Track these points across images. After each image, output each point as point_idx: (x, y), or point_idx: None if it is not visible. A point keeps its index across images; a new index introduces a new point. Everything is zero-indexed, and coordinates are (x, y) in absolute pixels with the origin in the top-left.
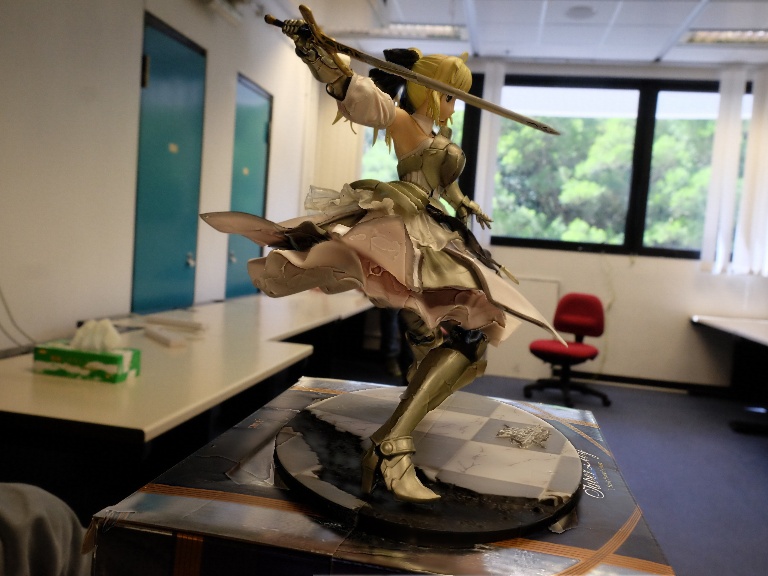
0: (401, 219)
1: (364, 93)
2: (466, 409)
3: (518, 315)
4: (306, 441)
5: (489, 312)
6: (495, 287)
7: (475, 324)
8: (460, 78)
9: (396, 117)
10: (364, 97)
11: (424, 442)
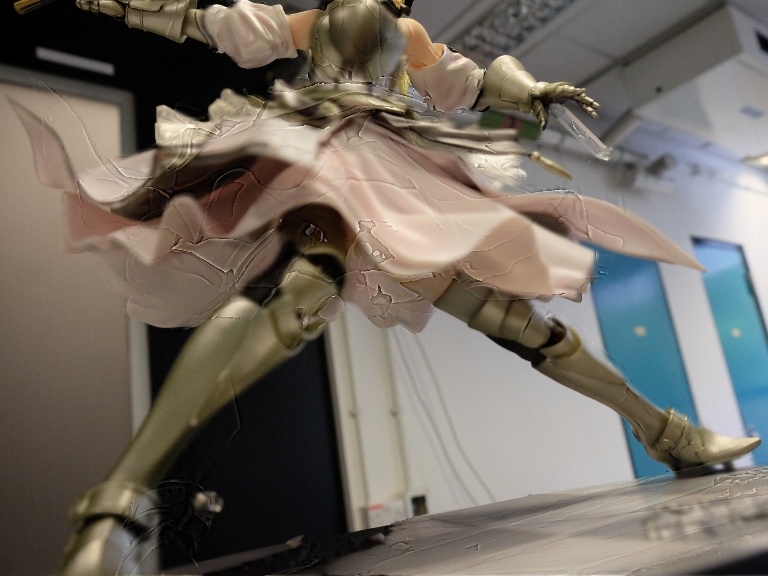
0: (23, 68)
1: (220, 15)
2: (736, 468)
3: (300, 113)
4: (303, 570)
5: (330, 164)
6: (285, 100)
7: (298, 199)
8: None
9: (291, 21)
10: (220, 20)
11: (510, 536)
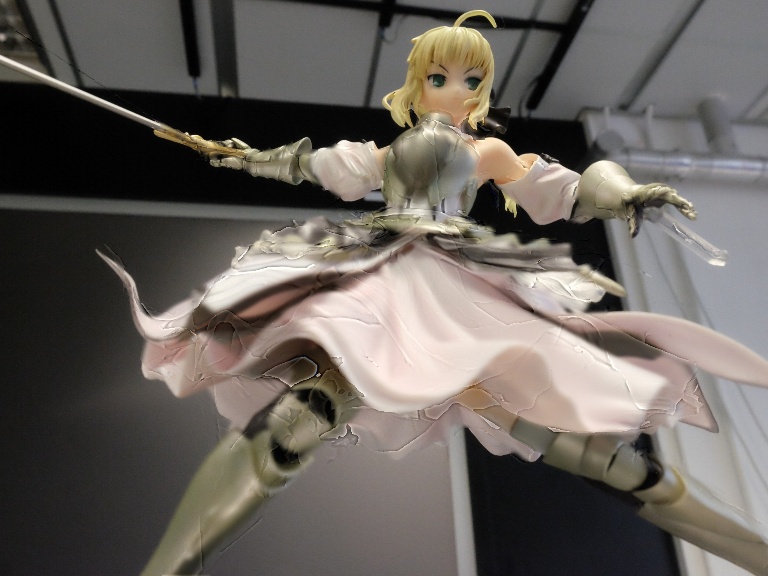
0: None
1: (316, 158)
2: None
3: None
4: None
5: (301, 302)
6: None
7: (271, 338)
8: (427, 47)
9: (376, 155)
10: (316, 162)
11: None
